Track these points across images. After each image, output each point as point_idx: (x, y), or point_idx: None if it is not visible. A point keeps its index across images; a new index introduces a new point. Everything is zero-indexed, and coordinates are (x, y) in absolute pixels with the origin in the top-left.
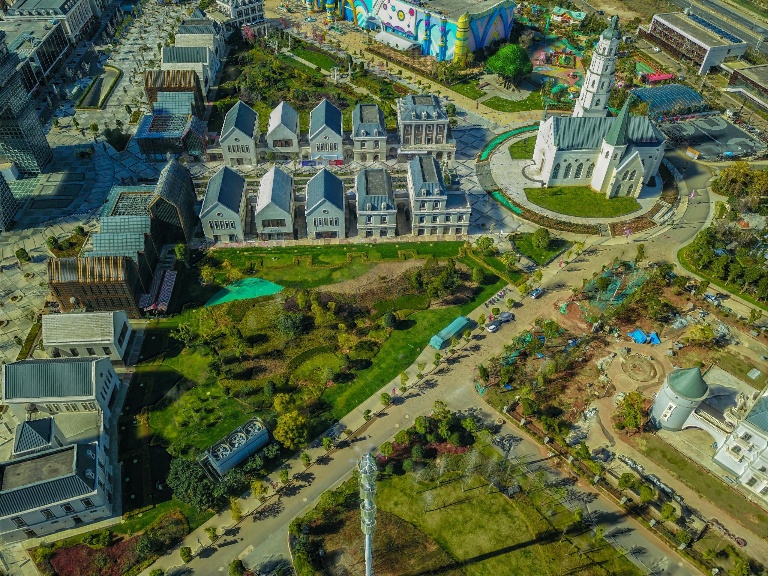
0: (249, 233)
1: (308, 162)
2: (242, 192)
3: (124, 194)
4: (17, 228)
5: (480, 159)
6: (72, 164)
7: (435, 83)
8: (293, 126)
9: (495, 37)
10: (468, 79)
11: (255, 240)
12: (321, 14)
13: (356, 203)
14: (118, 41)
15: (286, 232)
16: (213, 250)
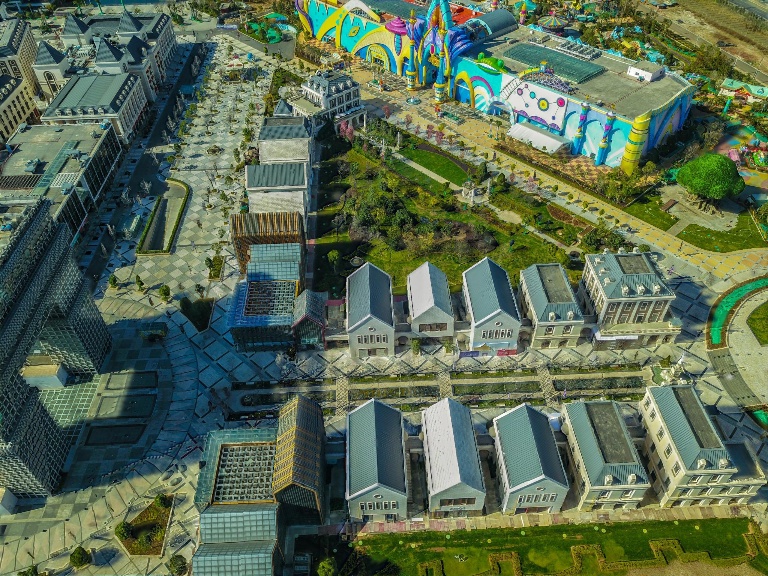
0: (411, 501)
1: (468, 353)
2: (402, 442)
3: (226, 447)
4: (69, 487)
5: (711, 343)
6: (139, 354)
7: (603, 202)
8: (447, 303)
9: (668, 130)
10: (645, 194)
11: (423, 516)
12: (424, 92)
13: (581, 466)
14: (180, 138)
15: (473, 509)
16: (363, 538)
